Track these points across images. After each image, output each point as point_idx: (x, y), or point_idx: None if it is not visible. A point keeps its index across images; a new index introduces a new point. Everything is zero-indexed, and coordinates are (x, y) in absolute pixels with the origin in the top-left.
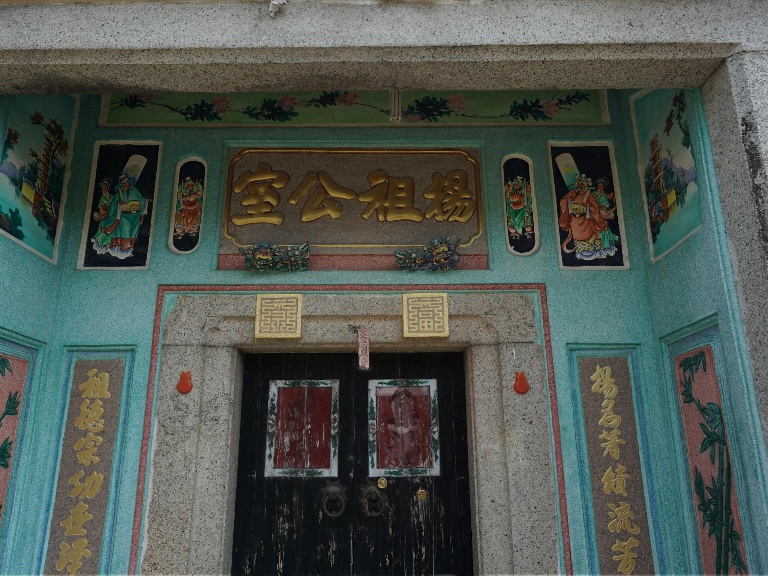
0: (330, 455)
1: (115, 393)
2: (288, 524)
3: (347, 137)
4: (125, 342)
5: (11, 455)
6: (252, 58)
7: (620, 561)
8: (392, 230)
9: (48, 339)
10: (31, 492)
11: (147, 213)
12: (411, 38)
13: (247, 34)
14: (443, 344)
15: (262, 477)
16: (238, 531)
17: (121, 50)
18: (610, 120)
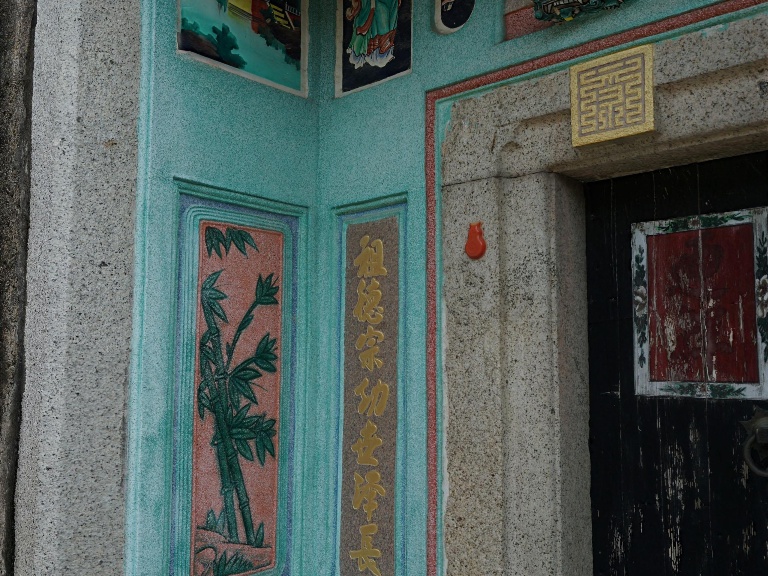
0: (757, 357)
1: (391, 267)
2: (683, 481)
3: None
4: (393, 190)
5: (278, 356)
6: None
7: None
8: None
9: (310, 201)
10: (318, 404)
11: None
12: None
13: None
14: None
15: (631, 395)
16: (598, 483)
17: None
18: None
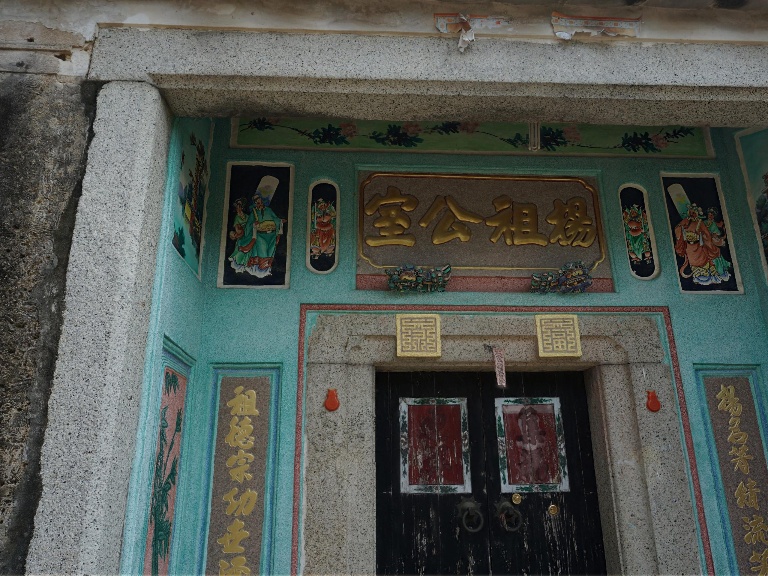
0: (463, 472)
1: (263, 410)
2: (426, 540)
3: (472, 163)
4: (271, 360)
5: (177, 472)
6: (443, 90)
7: (758, 572)
8: (520, 253)
9: (197, 356)
10: (187, 510)
11: (282, 233)
12: (592, 76)
13: (438, 68)
14: (573, 364)
15: (398, 494)
16: (378, 547)
17: (319, 79)
18: (715, 153)
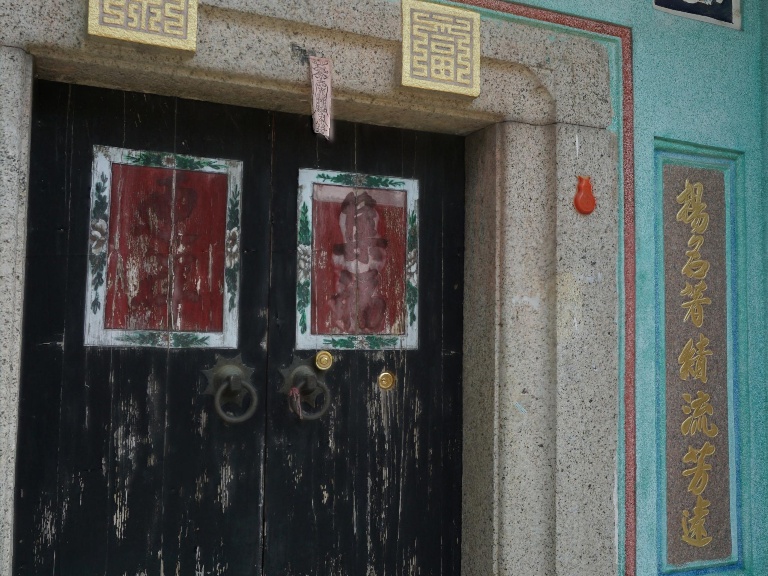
0: (223, 307)
1: None
2: (136, 438)
3: None
4: None
5: None
6: None
7: (691, 477)
8: None
9: None
10: None
11: None
12: None
13: None
14: (457, 112)
15: (78, 346)
16: (26, 456)
17: None
18: None
